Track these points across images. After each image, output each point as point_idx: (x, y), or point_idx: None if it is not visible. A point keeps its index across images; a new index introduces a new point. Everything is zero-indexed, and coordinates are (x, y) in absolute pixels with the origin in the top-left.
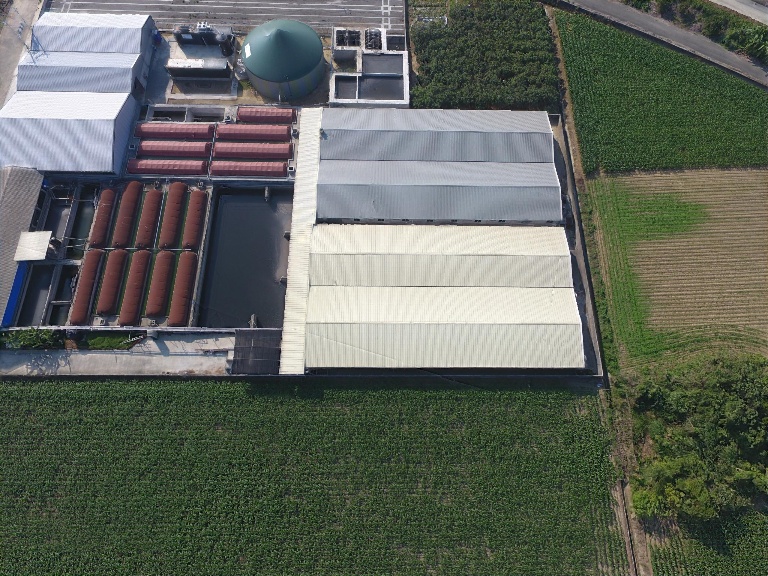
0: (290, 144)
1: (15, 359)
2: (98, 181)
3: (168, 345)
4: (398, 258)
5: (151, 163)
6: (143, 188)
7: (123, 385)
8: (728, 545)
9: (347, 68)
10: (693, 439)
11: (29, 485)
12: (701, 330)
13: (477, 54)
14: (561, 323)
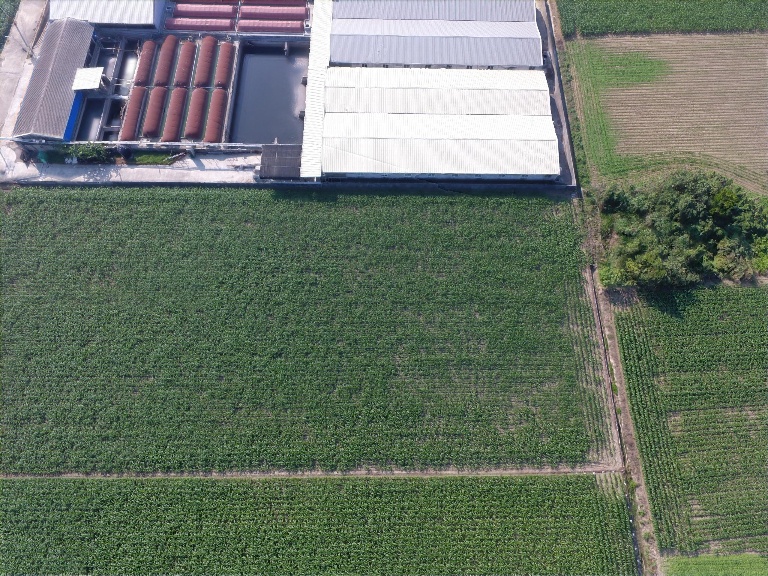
0: (306, 7)
1: (74, 171)
2: (140, 36)
3: (204, 162)
4: (400, 91)
5: (186, 20)
6: (179, 42)
7: (166, 190)
8: (680, 311)
9: None
10: (652, 232)
11: (90, 262)
12: (662, 155)
13: None
14: (540, 139)
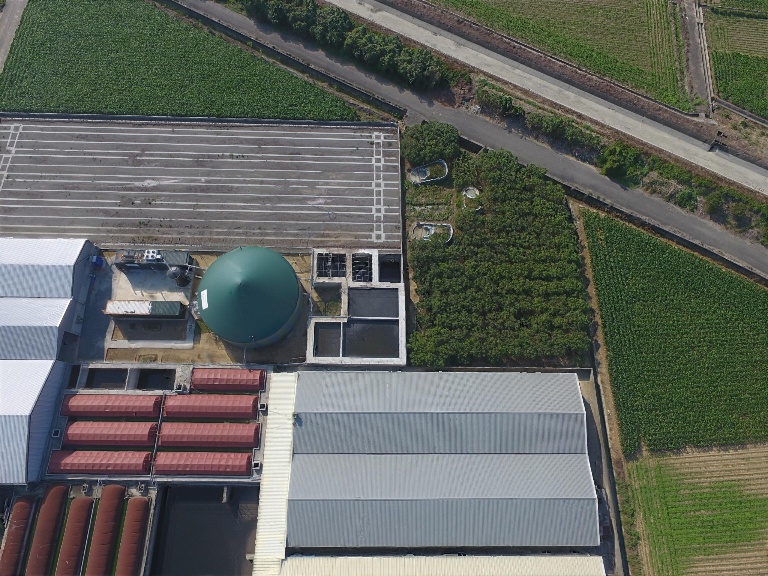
0: (256, 426)
1: None
2: None
3: None
4: None
5: (78, 462)
6: (68, 493)
7: None
8: None
9: (330, 301)
10: None
11: None
12: None
13: (490, 287)
14: None
